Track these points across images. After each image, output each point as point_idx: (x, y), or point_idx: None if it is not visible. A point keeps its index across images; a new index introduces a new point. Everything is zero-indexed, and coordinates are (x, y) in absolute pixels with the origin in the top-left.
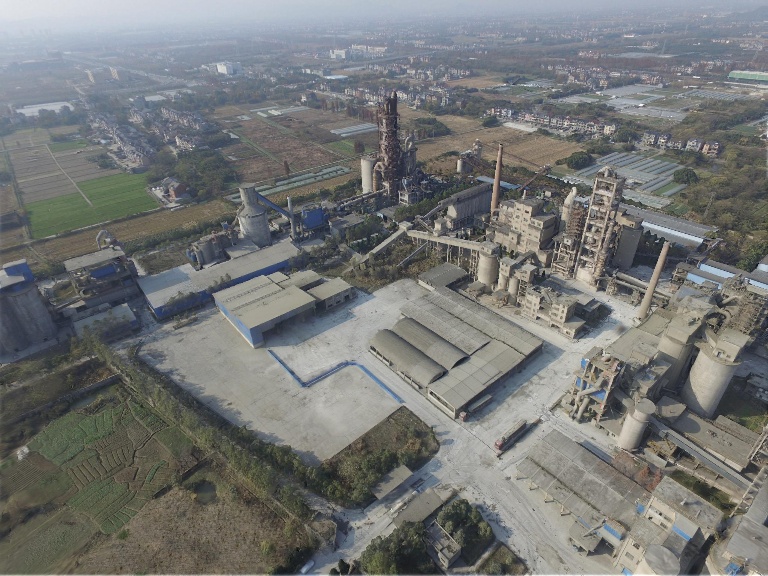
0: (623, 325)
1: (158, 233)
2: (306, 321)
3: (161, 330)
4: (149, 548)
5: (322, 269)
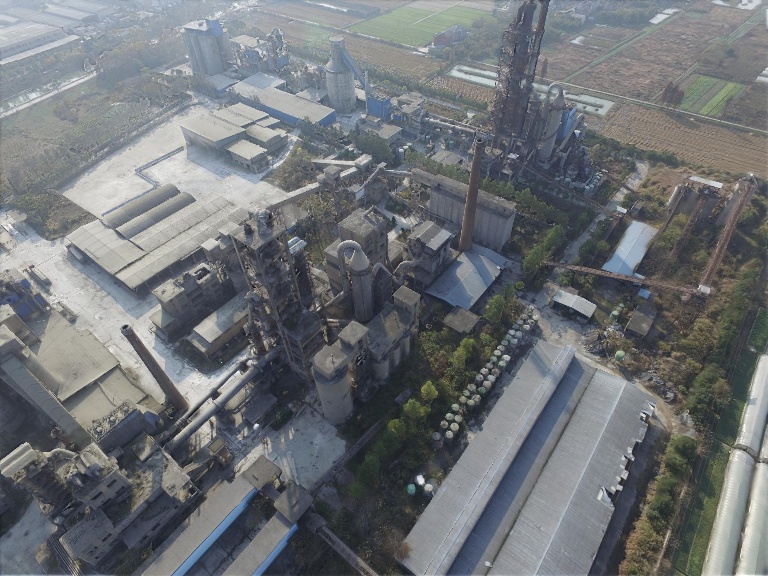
0: (173, 382)
1: (366, 62)
2: (219, 156)
3: (217, 105)
4: None
5: (307, 146)
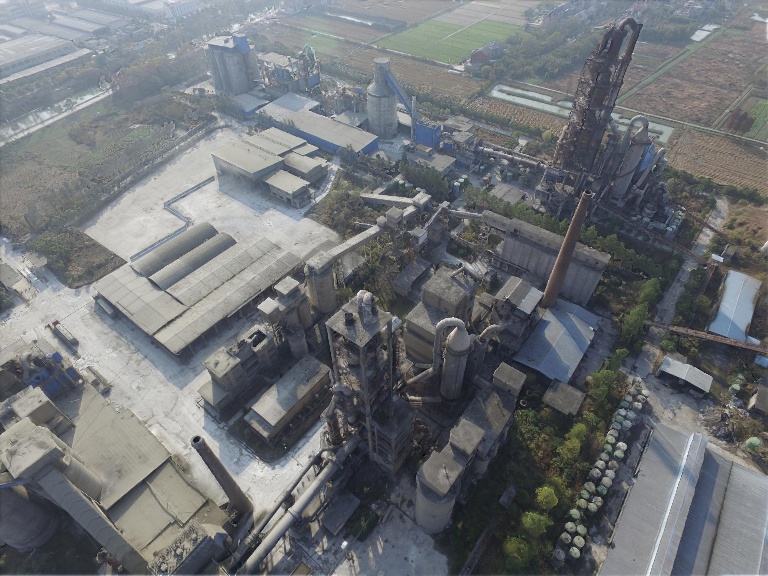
0: (231, 474)
1: (400, 80)
2: (254, 187)
3: (246, 128)
4: (48, 183)
5: (350, 177)
